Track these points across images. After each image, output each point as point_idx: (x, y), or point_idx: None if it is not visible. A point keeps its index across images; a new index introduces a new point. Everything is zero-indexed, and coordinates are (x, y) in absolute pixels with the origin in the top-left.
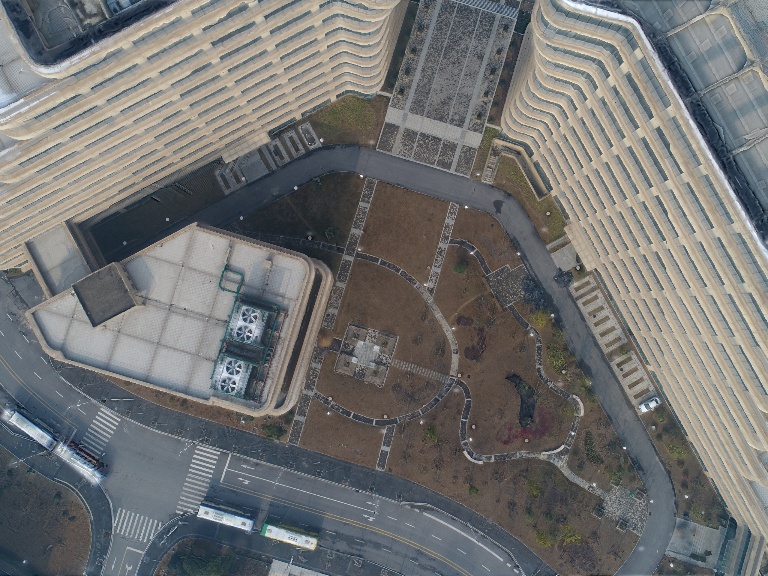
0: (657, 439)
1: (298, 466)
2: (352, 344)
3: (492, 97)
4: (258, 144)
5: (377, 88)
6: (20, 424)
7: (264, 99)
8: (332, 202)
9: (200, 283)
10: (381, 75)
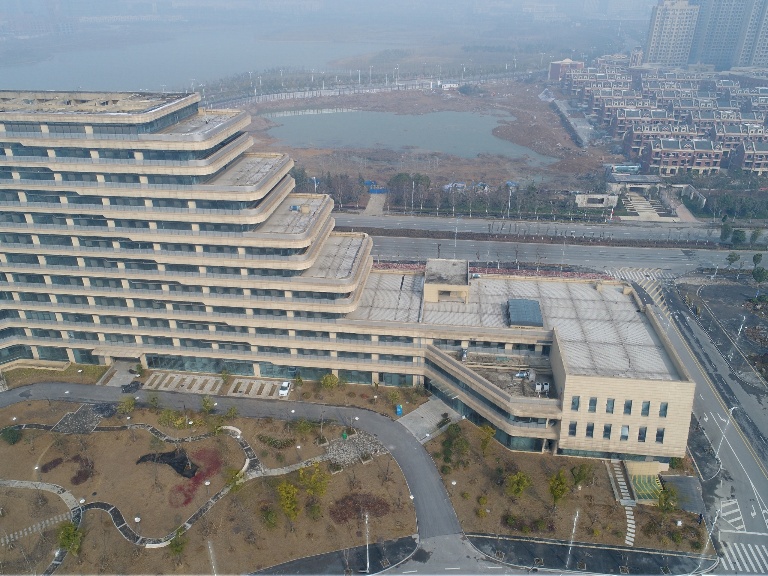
0: (316, 397)
1: None
2: None
3: None
4: None
5: None
6: None
7: None
8: None
9: None
10: None
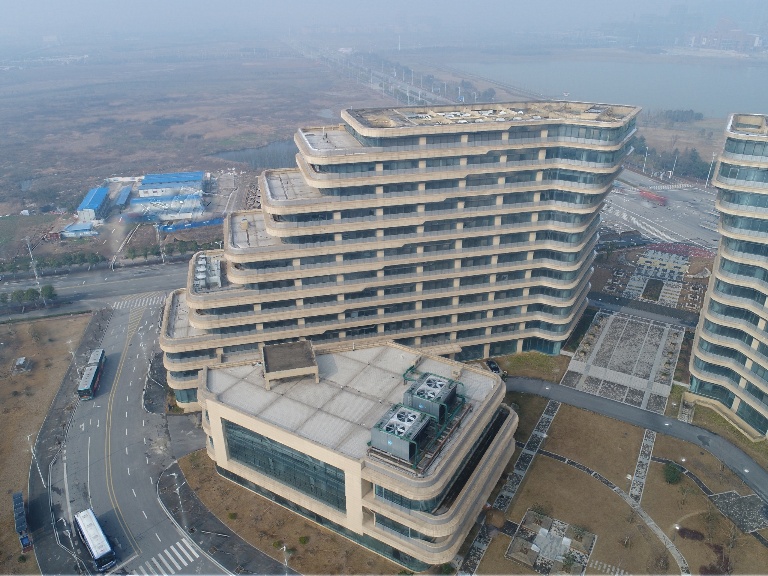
0: None
1: None
2: (532, 531)
3: (674, 367)
4: (450, 350)
5: (562, 337)
6: (84, 521)
7: (473, 290)
8: None
9: (382, 377)
10: (569, 318)
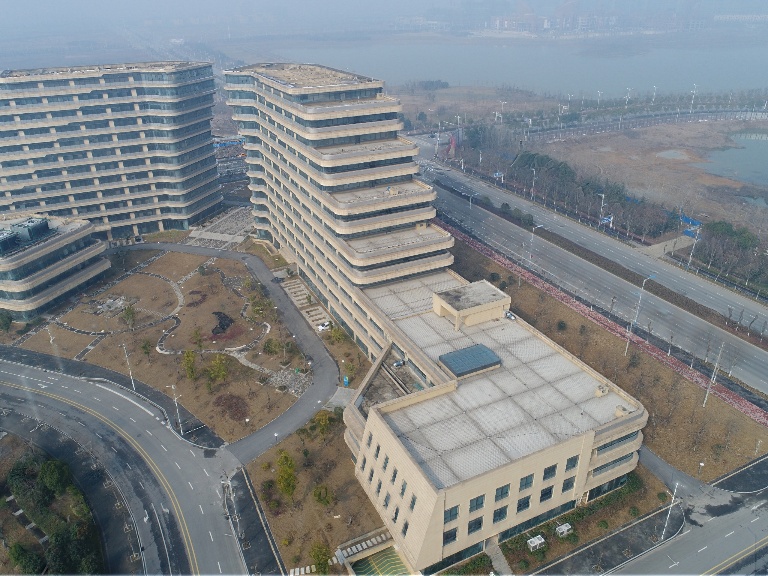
0: None
1: (6, 357)
2: (104, 302)
3: None
4: (102, 229)
5: (186, 216)
6: None
7: (110, 186)
8: (135, 256)
9: None
10: (187, 203)
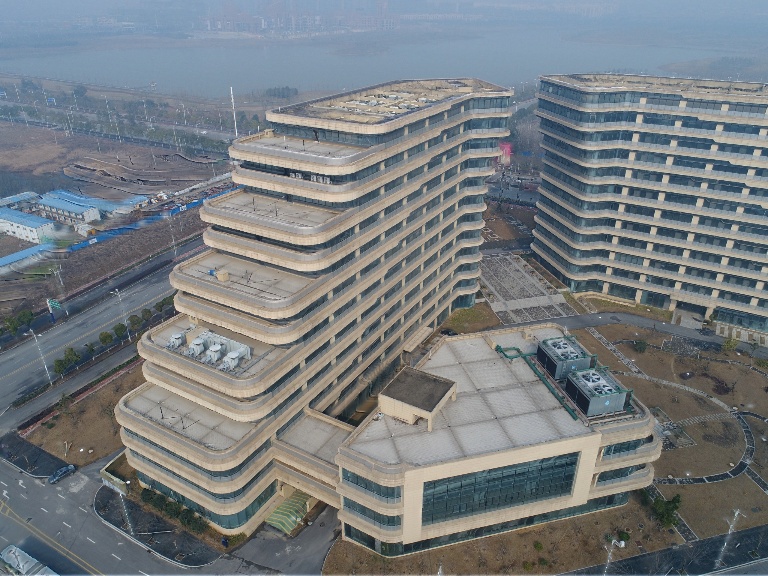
0: None
1: (726, 560)
2: None
3: (545, 280)
4: (426, 333)
5: (478, 287)
6: None
7: (431, 269)
8: None
9: (487, 368)
10: (479, 270)
